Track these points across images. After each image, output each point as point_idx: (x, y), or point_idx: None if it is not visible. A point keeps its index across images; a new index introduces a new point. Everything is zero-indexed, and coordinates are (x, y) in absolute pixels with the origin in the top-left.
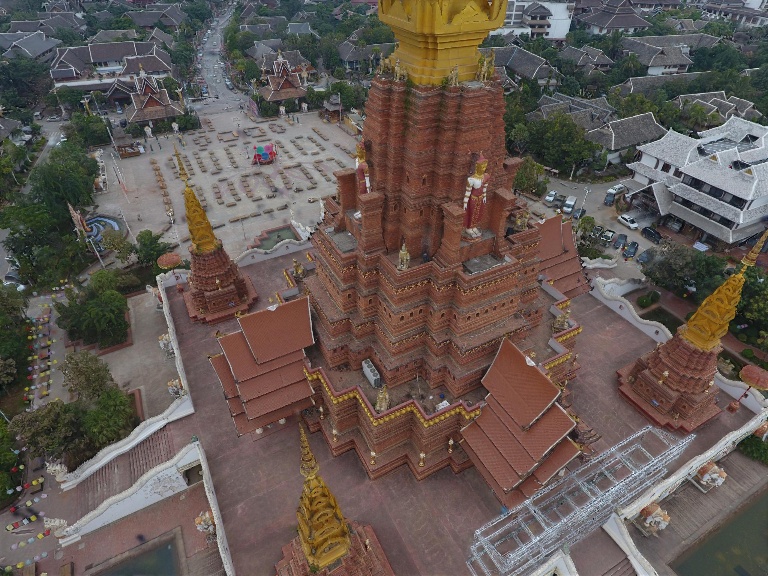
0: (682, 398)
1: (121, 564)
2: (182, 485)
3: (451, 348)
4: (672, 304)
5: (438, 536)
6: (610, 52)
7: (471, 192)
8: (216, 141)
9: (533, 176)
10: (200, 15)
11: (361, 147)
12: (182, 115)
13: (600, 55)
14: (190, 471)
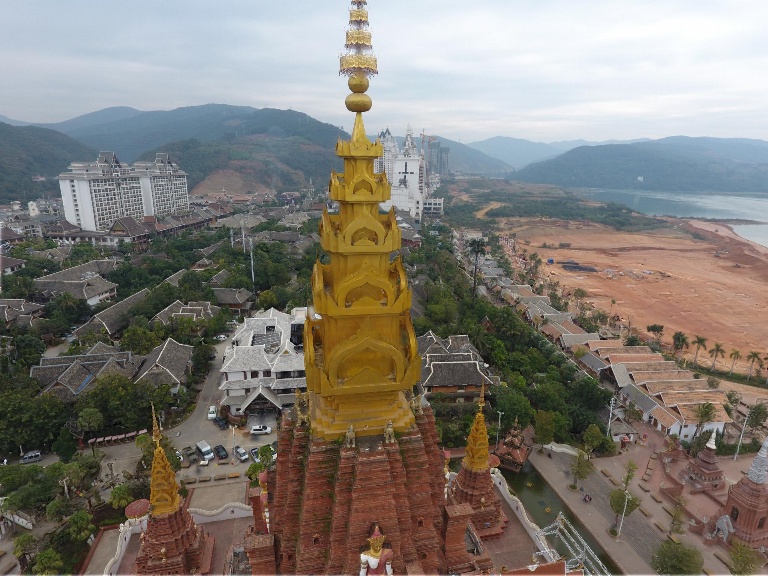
0: None
1: None
2: None
3: None
4: None
5: None
6: (27, 297)
7: None
8: None
9: (173, 449)
10: None
11: (384, 537)
12: None
13: (24, 304)
14: None
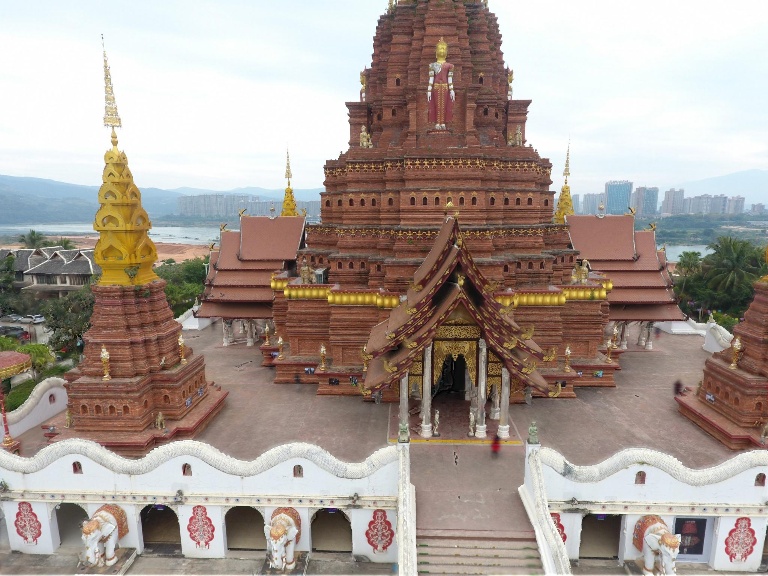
0: None
1: None
2: None
3: None
4: None
5: None
6: None
7: None
8: None
9: None
10: None
11: None
12: None
13: None
14: None
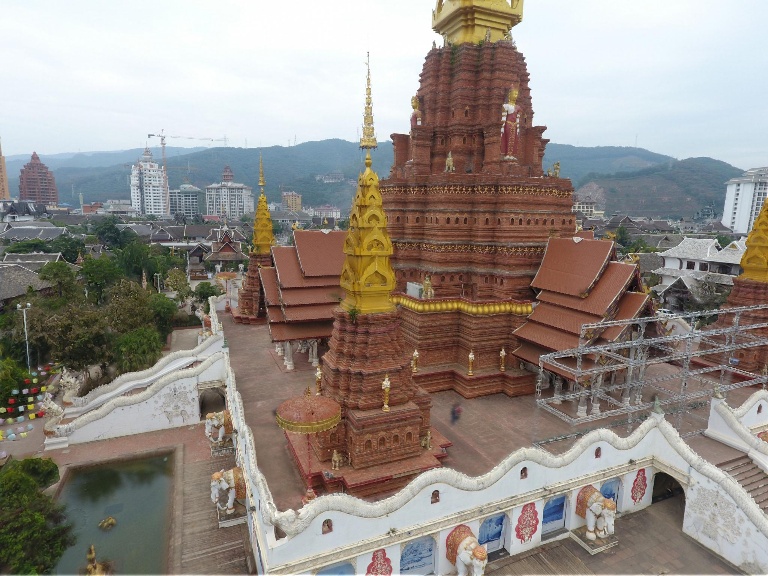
0: (763, 348)
1: (106, 465)
2: (195, 415)
3: (497, 257)
4: None
5: (494, 429)
6: (619, 242)
7: (506, 118)
8: None
9: None
10: (273, 230)
11: (416, 97)
12: None
13: None
14: (205, 410)
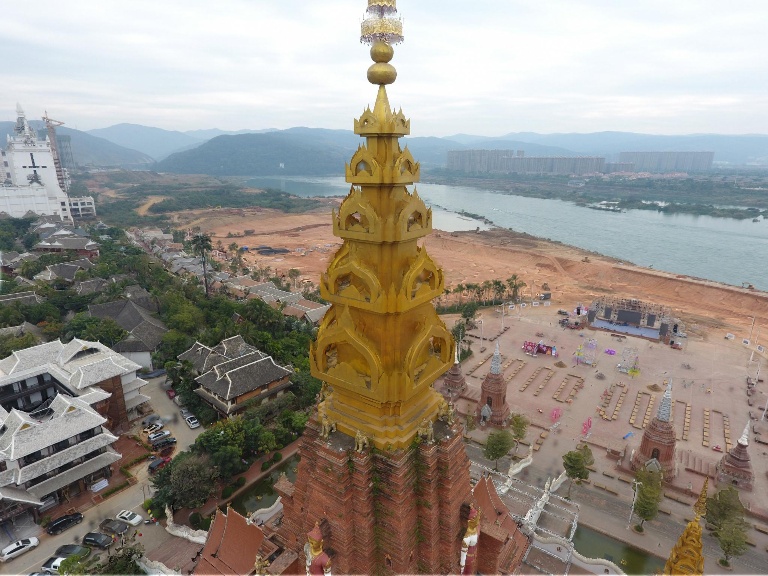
0: None
1: None
2: None
3: None
4: (202, 508)
5: None
6: None
7: None
8: None
9: None
10: None
11: None
12: None
13: None
14: None
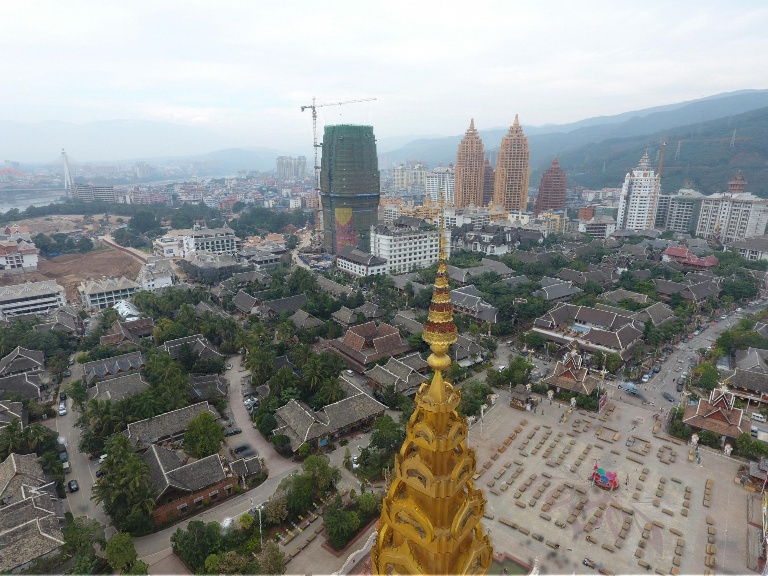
0: None
1: None
2: None
3: None
4: None
5: None
6: None
7: None
8: (592, 433)
9: None
10: (738, 293)
11: None
12: (586, 395)
13: None
14: None
